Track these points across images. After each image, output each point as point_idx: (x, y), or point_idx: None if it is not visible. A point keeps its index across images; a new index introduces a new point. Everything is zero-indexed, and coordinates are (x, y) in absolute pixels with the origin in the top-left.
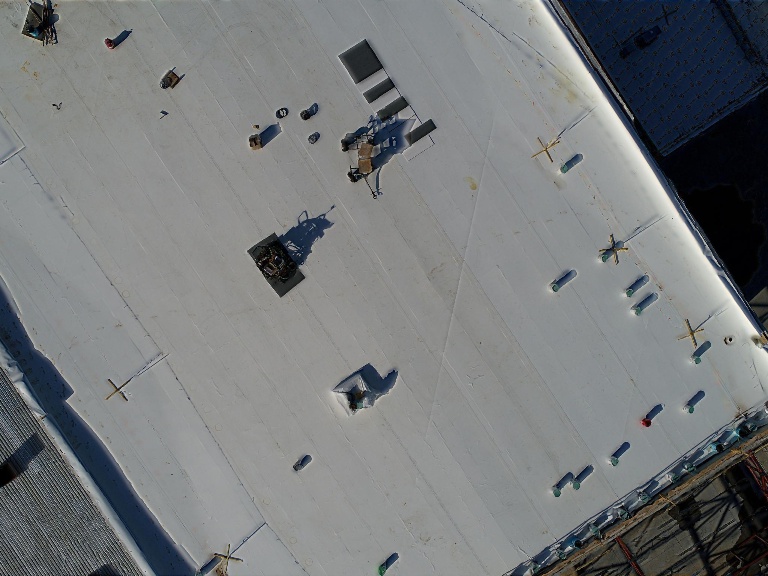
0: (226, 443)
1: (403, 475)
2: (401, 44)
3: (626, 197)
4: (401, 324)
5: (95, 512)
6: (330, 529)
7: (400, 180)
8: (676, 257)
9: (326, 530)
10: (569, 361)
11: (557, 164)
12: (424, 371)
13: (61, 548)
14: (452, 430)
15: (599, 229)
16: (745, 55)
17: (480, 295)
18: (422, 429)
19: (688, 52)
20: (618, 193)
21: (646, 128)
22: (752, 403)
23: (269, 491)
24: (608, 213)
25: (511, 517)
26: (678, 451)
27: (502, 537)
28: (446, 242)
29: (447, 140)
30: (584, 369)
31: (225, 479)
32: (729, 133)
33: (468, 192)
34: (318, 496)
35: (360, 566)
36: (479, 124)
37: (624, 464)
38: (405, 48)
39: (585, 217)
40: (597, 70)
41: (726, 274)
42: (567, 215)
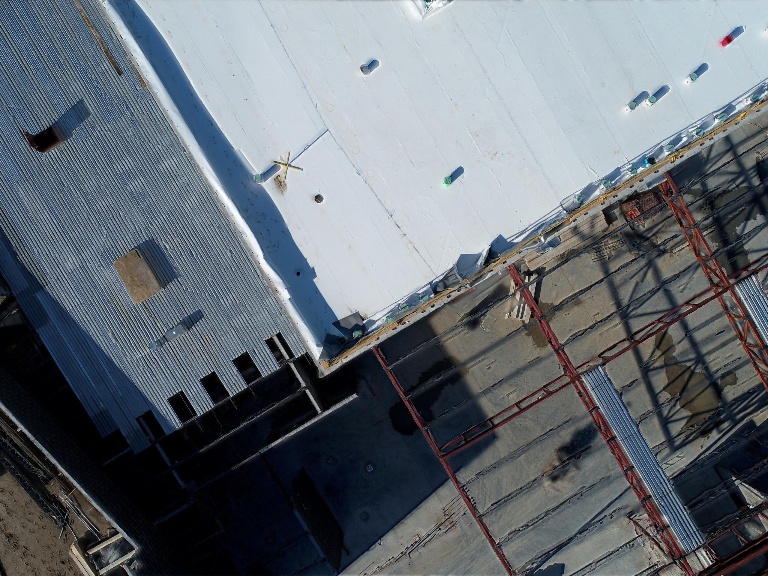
0: (291, 45)
1: (473, 85)
2: None
3: None
4: None
5: (139, 185)
6: (395, 139)
7: None
8: None
9: (390, 140)
10: None
11: None
12: None
13: (102, 221)
14: (526, 39)
15: None
16: None
17: None
18: (495, 37)
19: None
20: None
21: None
22: None
23: (333, 97)
24: None
25: (582, 134)
26: (757, 75)
27: (572, 154)
28: None
29: None
30: None
31: (288, 82)
32: None
33: None
34: (384, 104)
35: (424, 179)
36: None
37: (701, 86)
38: None
39: None
40: None
41: None
42: None
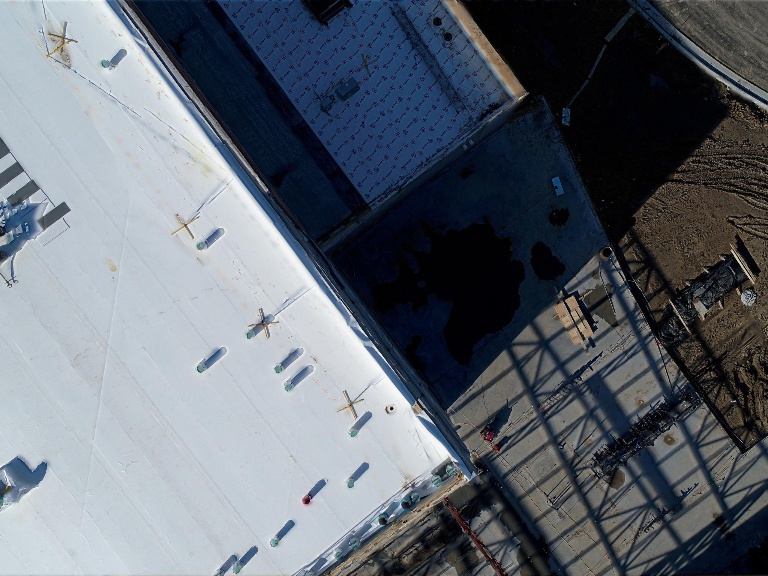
0: None
1: (61, 568)
2: (28, 127)
3: (272, 269)
4: (47, 414)
5: None
6: None
7: (36, 266)
8: (329, 327)
9: None
10: (225, 441)
11: (196, 240)
12: (75, 461)
13: None
14: (108, 519)
15: (247, 304)
16: (450, 101)
17: (128, 379)
18: (77, 520)
19: (392, 101)
20: (263, 266)
21: (353, 181)
22: (418, 472)
23: None
24: (255, 287)
25: None
26: (344, 526)
27: None
28: (88, 327)
29: (83, 222)
30: (241, 448)
31: None
32: (480, 171)
33: (108, 274)
34: None
35: None
36: (115, 204)
37: (289, 543)
38: (32, 130)
39: (232, 292)
40: (226, 143)
41: (374, 344)
42: (213, 291)
